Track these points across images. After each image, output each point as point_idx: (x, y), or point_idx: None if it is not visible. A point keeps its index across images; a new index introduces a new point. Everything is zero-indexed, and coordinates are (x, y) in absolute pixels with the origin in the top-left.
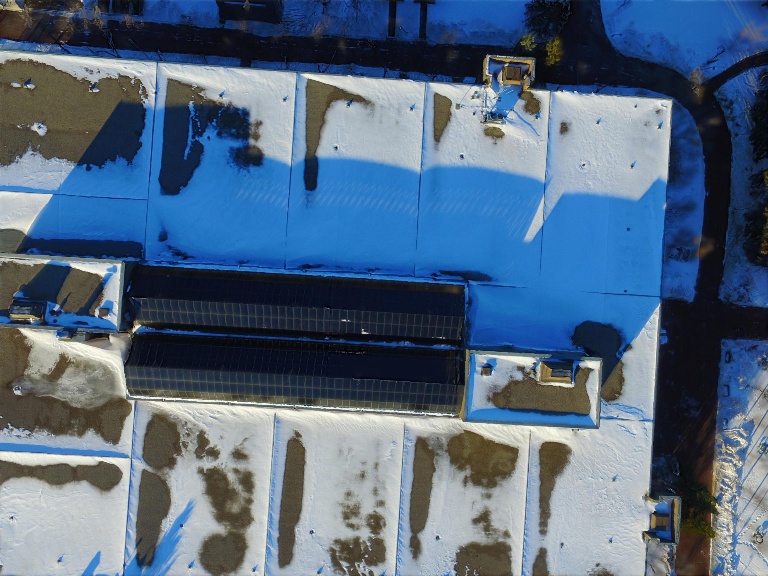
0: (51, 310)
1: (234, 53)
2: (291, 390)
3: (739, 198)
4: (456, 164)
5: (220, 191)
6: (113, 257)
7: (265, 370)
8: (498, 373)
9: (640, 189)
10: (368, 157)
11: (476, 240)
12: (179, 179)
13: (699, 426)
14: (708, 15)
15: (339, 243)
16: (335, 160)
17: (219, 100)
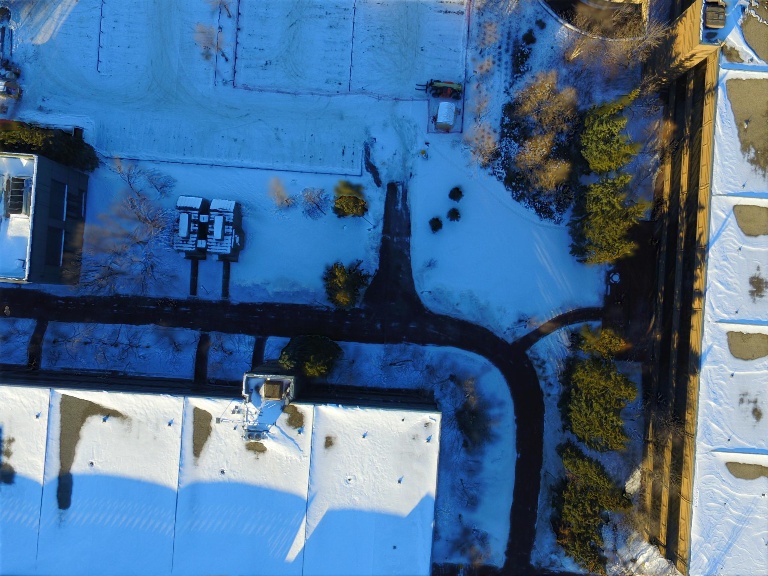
0: None
1: (31, 314)
2: None
3: (551, 461)
4: (216, 480)
5: None
6: None
7: None
8: None
9: (408, 505)
10: (125, 473)
11: (235, 560)
12: None
13: None
14: (520, 271)
15: (92, 565)
16: (91, 476)
17: None
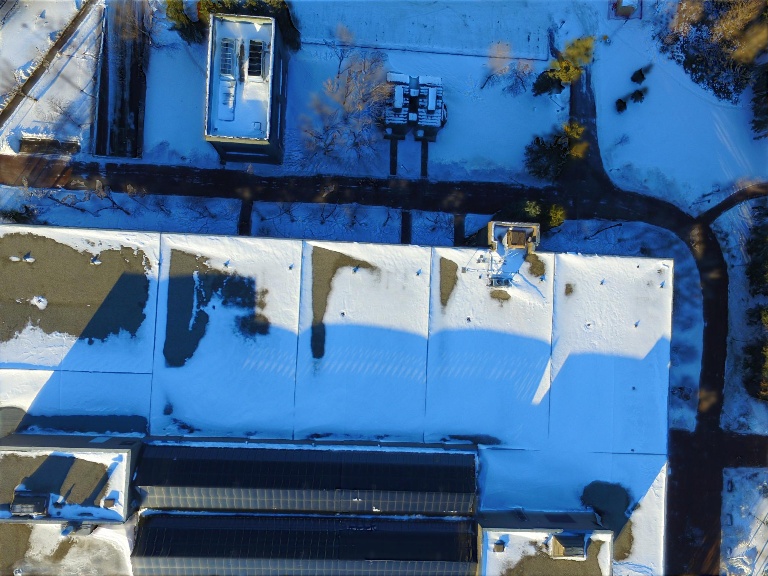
0: (54, 502)
1: (235, 194)
2: (302, 572)
3: (736, 328)
4: (463, 327)
5: (226, 362)
6: (117, 432)
7: (276, 555)
8: (510, 549)
9: (644, 348)
10: (375, 323)
11: (484, 403)
12: (184, 350)
13: (704, 555)
14: (702, 149)
15: (347, 411)
16: (342, 326)
17: (224, 269)
